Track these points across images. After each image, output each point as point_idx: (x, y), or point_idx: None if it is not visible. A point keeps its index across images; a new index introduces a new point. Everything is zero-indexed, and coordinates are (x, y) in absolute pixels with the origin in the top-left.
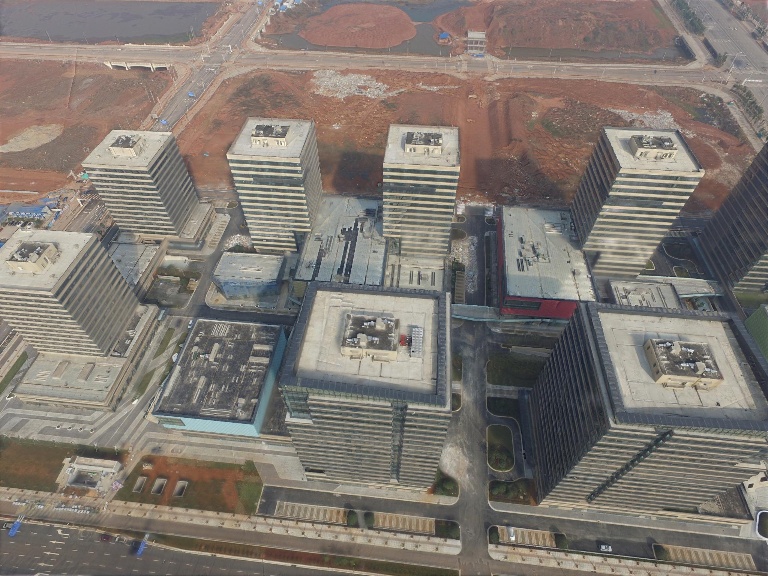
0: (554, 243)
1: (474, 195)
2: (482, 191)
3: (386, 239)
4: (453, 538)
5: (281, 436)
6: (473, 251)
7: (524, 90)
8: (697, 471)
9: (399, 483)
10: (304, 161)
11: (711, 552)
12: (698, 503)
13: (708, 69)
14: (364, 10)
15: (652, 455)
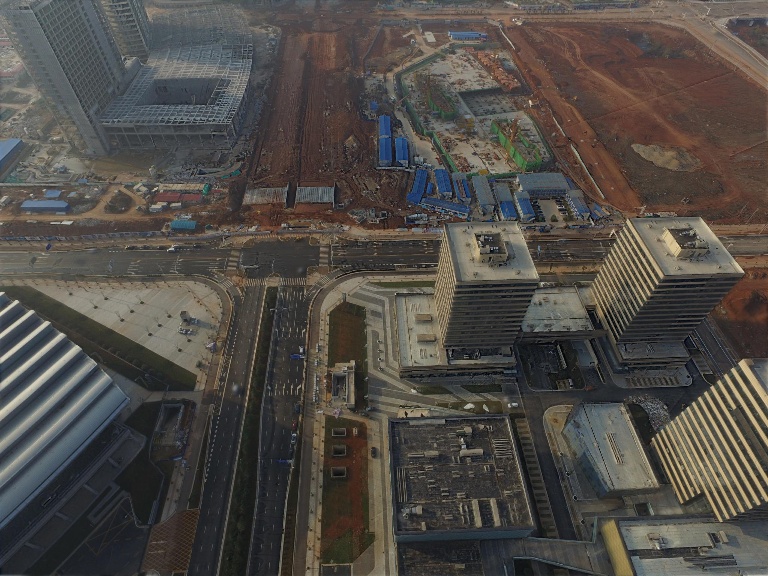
0: None
1: None
2: None
3: None
4: None
5: (398, 573)
6: None
7: None
8: None
9: None
10: None
11: None
12: None
13: None
14: None
15: None
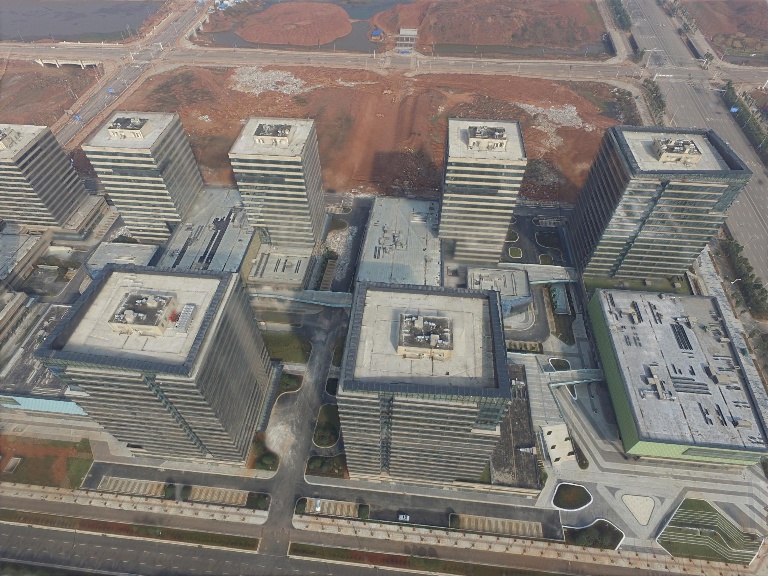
0: (416, 232)
1: (365, 187)
2: (374, 183)
3: (254, 228)
4: (261, 509)
5: None
6: (350, 241)
7: (439, 85)
8: (447, 438)
9: (214, 457)
10: (160, 152)
11: (504, 521)
12: (477, 472)
13: (626, 64)
14: (303, 8)
15: (394, 422)
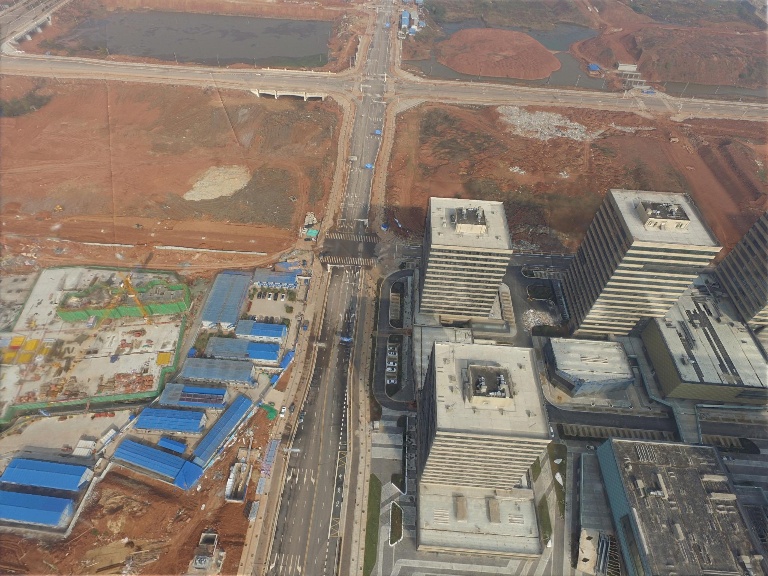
0: None
1: None
2: None
3: (746, 325)
4: None
5: None
6: None
7: (722, 133)
8: None
9: None
10: None
11: None
12: None
13: None
14: (495, 36)
15: None
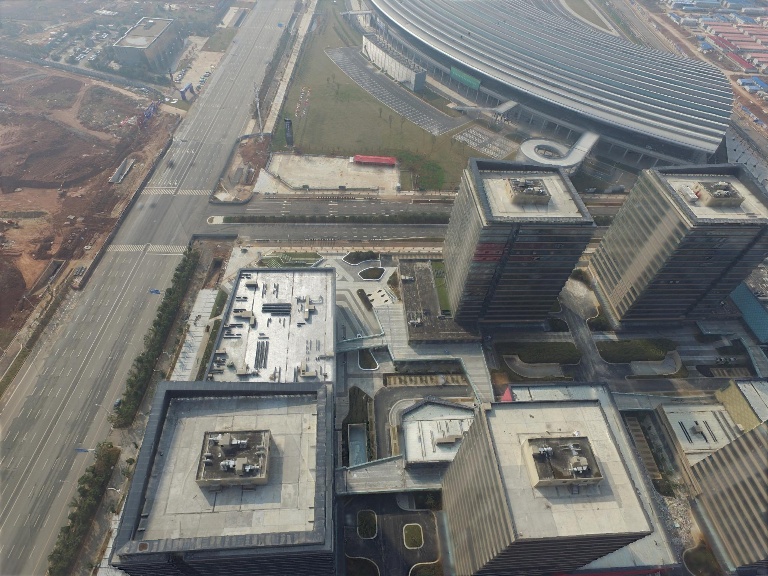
0: None
1: None
2: None
3: None
4: None
5: None
6: None
7: None
8: None
9: None
10: None
11: None
12: None
13: None
14: None
15: None
